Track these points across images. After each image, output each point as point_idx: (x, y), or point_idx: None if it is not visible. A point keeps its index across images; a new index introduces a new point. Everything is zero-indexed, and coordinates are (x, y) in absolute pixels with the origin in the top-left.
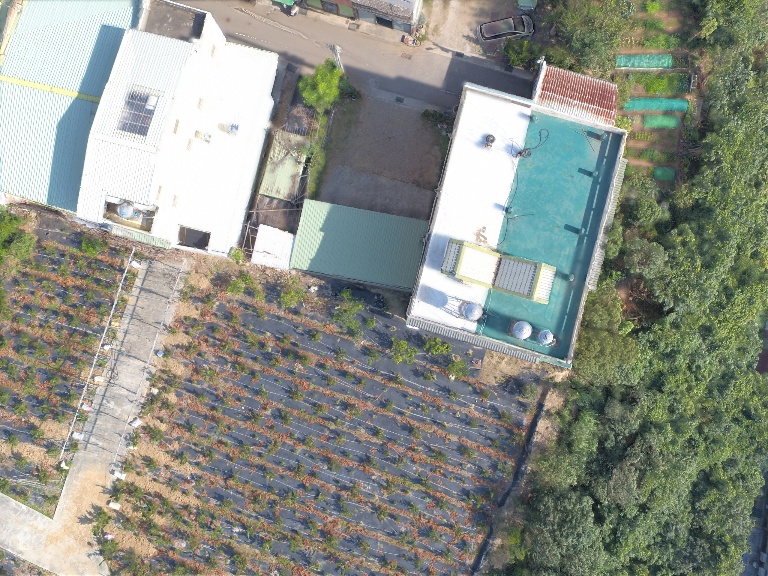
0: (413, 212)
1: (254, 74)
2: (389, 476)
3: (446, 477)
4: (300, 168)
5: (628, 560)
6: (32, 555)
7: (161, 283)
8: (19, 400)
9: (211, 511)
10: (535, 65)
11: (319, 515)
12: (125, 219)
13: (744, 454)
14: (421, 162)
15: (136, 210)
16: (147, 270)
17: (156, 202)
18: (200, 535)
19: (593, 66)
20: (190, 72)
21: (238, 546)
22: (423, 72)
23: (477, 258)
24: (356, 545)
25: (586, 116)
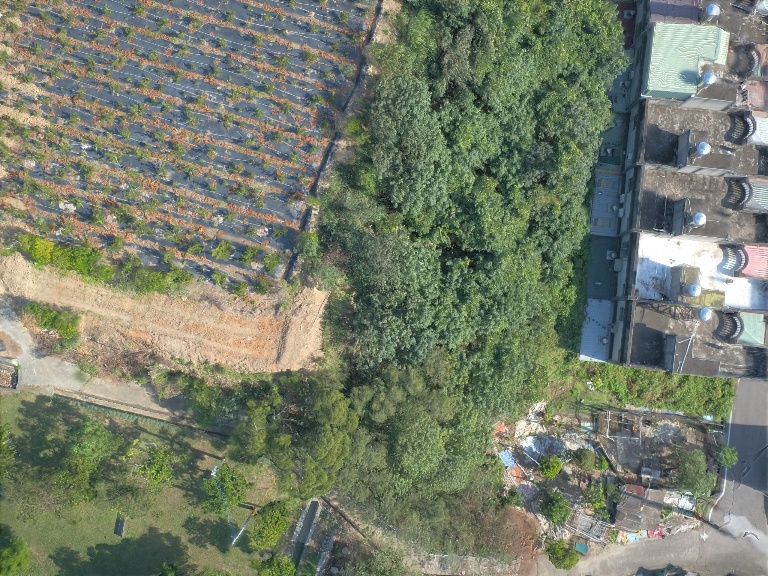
0: None
1: None
2: (234, 87)
3: (289, 83)
4: None
5: (474, 163)
6: None
7: None
8: None
9: (60, 131)
10: None
11: (167, 128)
12: None
13: (586, 69)
14: None
15: None
16: None
17: None
18: (50, 155)
19: None
20: None
21: (88, 163)
22: None
23: None
24: (204, 153)
25: None
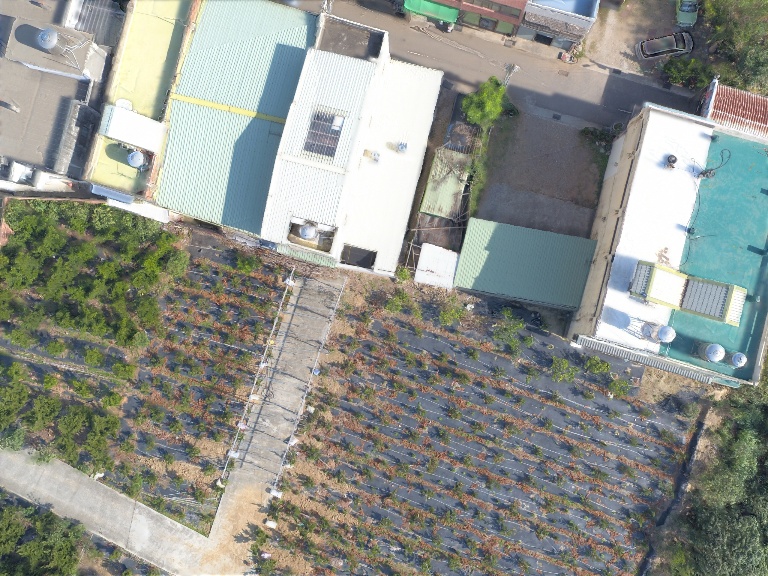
0: (572, 230)
1: (420, 92)
2: (547, 495)
3: (605, 496)
4: (462, 186)
5: None
6: (187, 574)
7: (316, 301)
8: (173, 418)
9: (368, 530)
10: (697, 83)
11: (477, 534)
12: (302, 239)
13: None
14: (579, 180)
15: (318, 231)
16: (302, 288)
17: (338, 223)
18: (357, 554)
19: (762, 84)
20: (373, 92)
21: (395, 565)
22: (580, 89)
23: (666, 280)
24: (515, 564)
25: (758, 135)
